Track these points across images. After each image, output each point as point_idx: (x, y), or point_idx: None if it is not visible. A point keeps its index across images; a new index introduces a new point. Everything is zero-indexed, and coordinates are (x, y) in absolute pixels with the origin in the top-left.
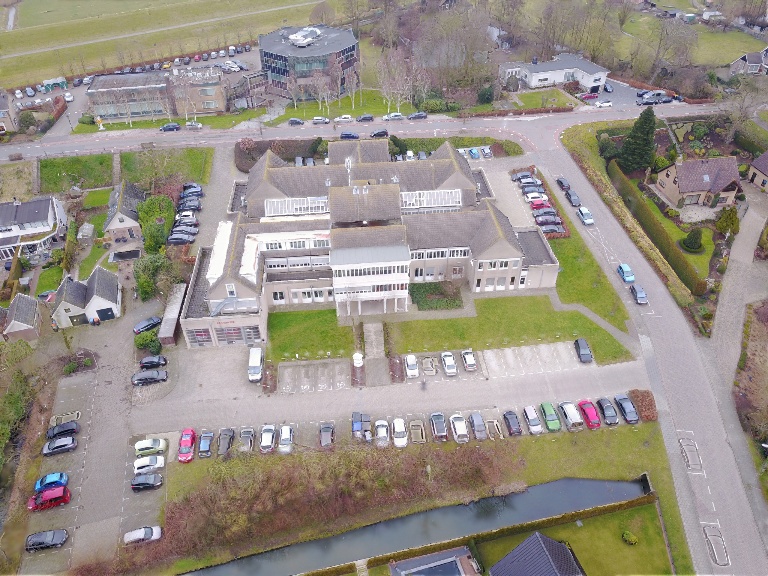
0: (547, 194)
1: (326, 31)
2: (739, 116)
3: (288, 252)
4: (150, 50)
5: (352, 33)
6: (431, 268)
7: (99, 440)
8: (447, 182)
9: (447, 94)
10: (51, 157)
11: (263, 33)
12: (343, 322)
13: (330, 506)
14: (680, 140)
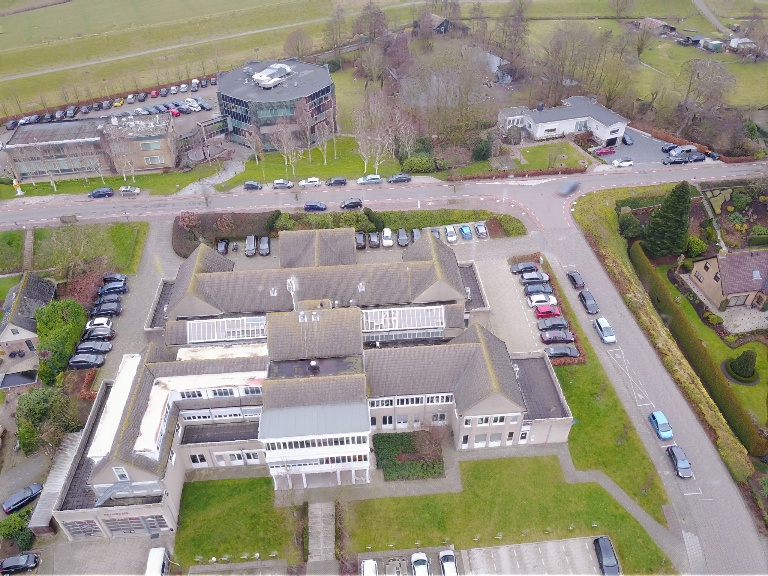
0: (556, 295)
1: (298, 67)
2: None
3: (211, 401)
4: (104, 82)
5: (328, 70)
6: (403, 415)
7: None
8: (427, 292)
9: (436, 148)
10: None
11: (234, 61)
12: (282, 500)
13: None
14: (717, 212)
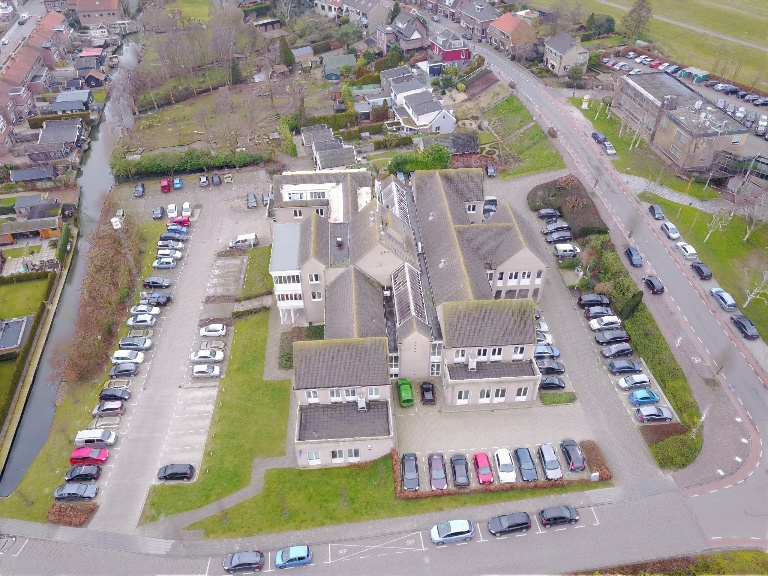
0: None
1: None
2: None
3: None
4: None
5: None
6: None
7: (206, 194)
8: None
9: None
10: (517, 97)
11: None
12: None
13: None
14: None
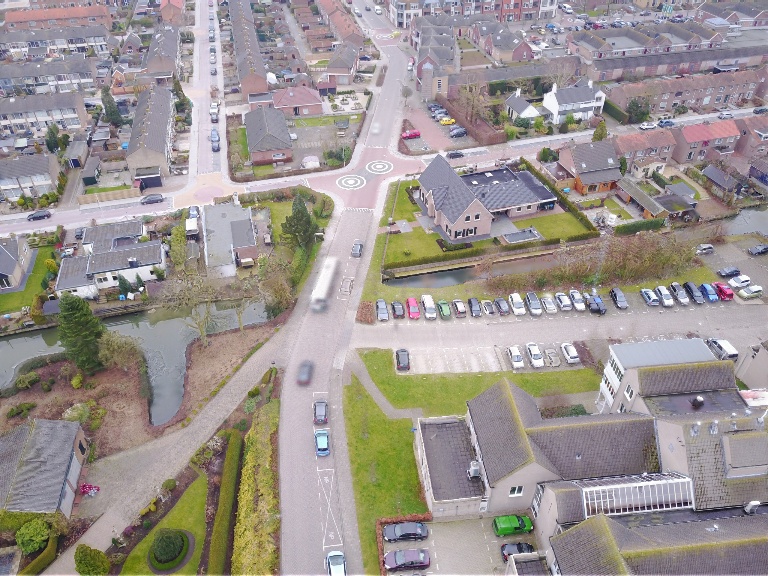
0: None
1: None
2: None
3: None
4: None
5: None
6: None
7: None
8: None
9: None
10: None
11: None
12: None
13: None
14: None
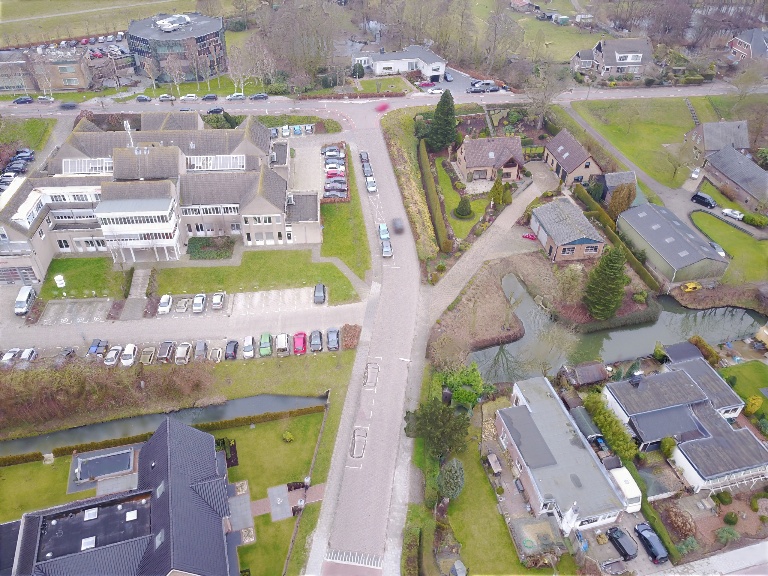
0: (345, 165)
1: (199, 19)
2: (537, 102)
3: (72, 204)
4: (44, 33)
5: (221, 21)
6: (210, 224)
7: None
8: (238, 149)
9: None
10: None
11: None
12: (117, 268)
13: (35, 408)
14: (495, 124)
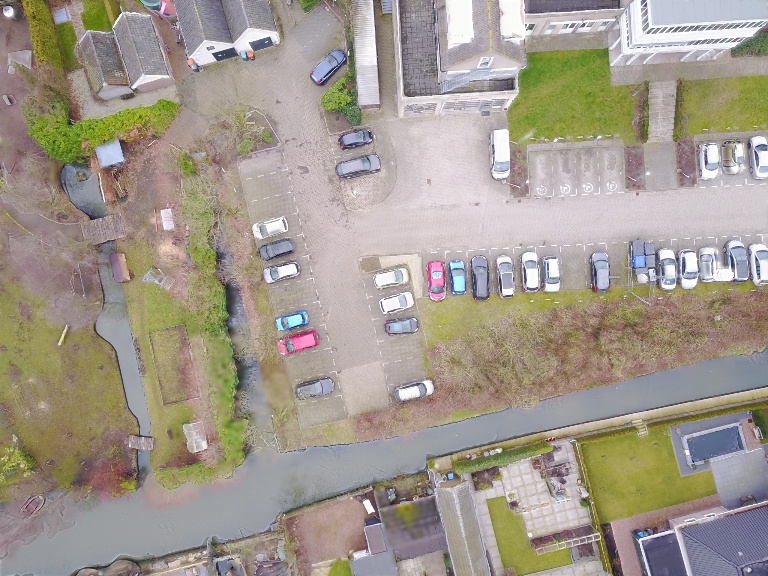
0: None
1: None
2: None
3: None
4: None
5: None
6: None
7: (323, 261)
8: None
9: None
10: None
11: None
12: (619, 77)
13: None
14: None
